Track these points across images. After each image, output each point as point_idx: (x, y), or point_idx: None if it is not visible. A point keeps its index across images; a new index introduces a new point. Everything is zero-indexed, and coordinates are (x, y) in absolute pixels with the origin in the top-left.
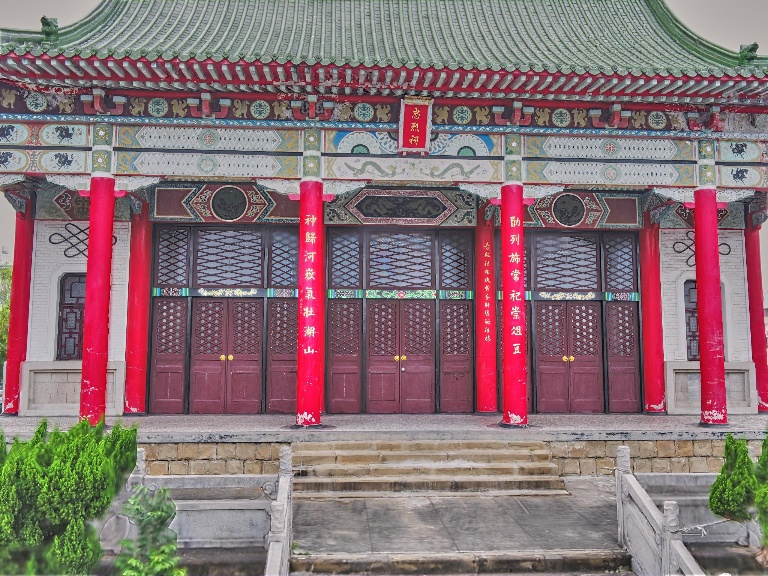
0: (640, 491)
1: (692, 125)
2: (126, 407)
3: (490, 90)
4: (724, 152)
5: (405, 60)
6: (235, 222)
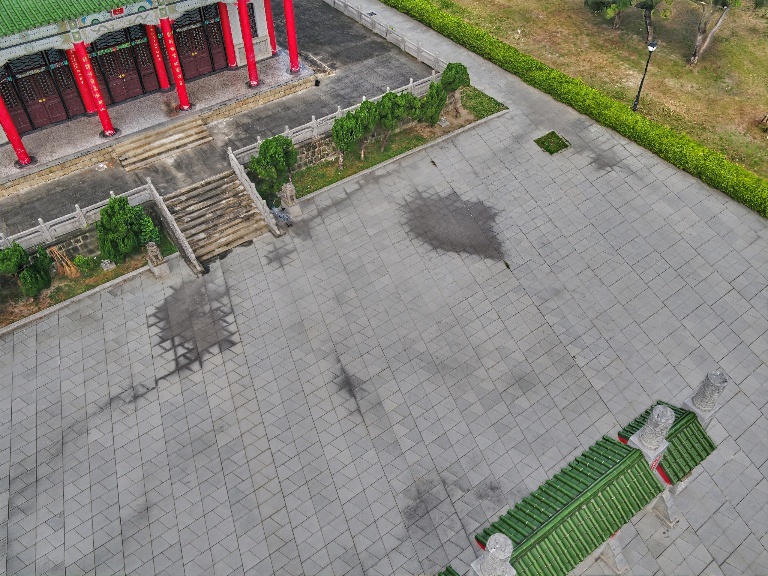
0: (235, 160)
1: None
2: None
3: None
4: None
5: (118, 5)
6: None
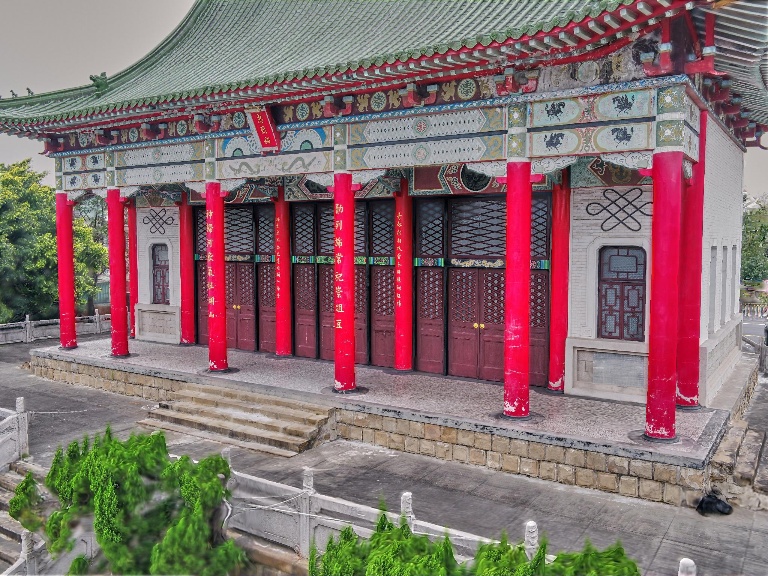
0: None
1: (499, 90)
2: (181, 339)
3: (288, 95)
4: (537, 116)
5: (204, 88)
6: (232, 203)
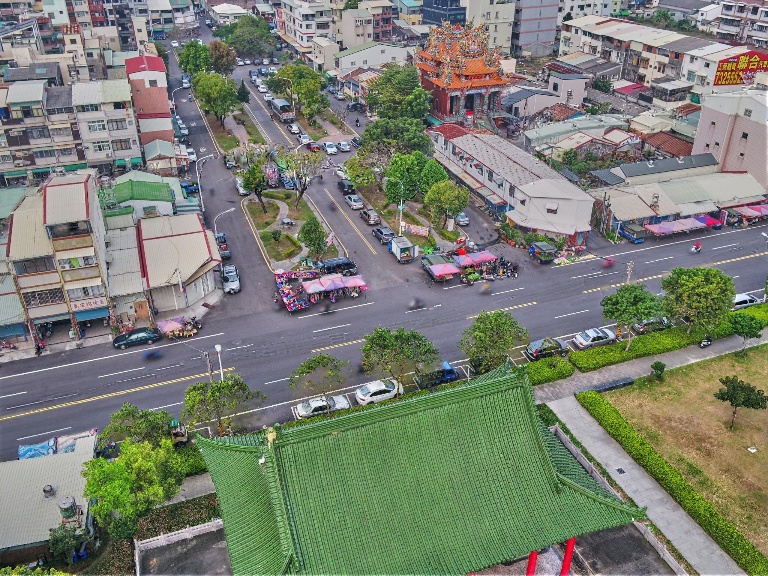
0: None
1: None
2: None
3: None
4: None
5: None
6: None
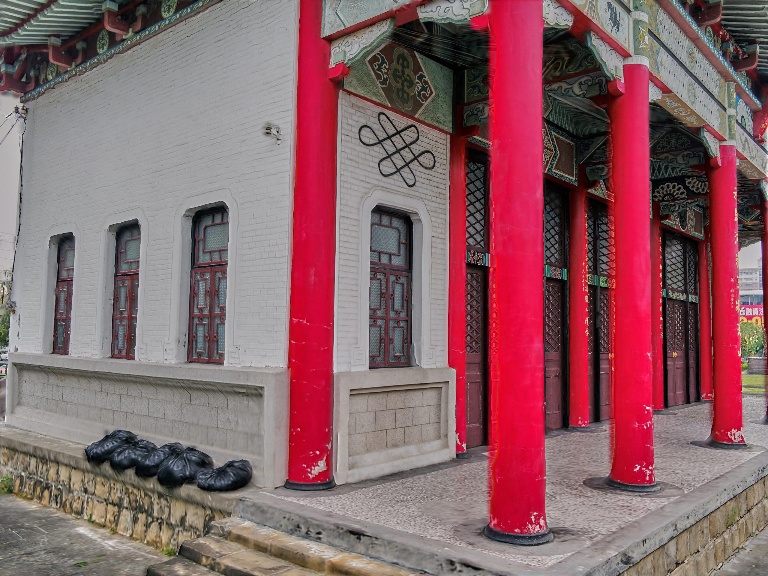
0: None
1: None
2: (457, 444)
3: None
4: None
5: None
6: None
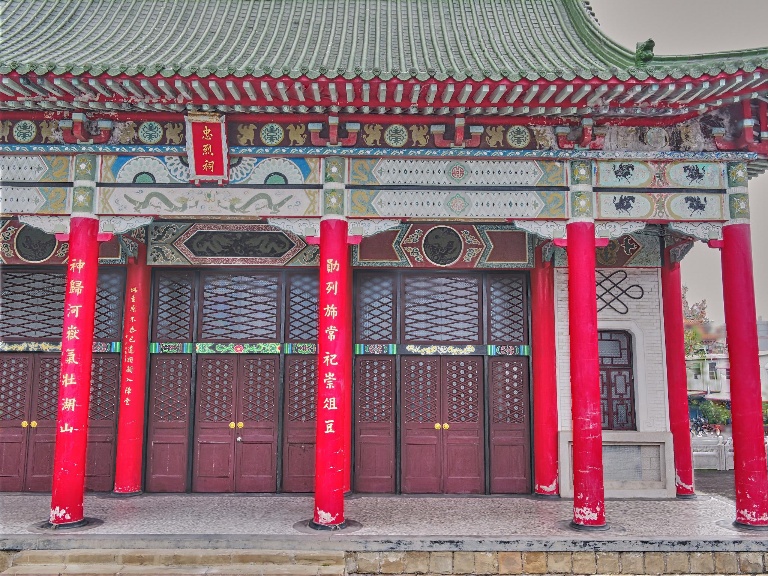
0: None
1: (562, 142)
2: None
3: (287, 103)
4: (604, 175)
5: (160, 66)
6: (42, 263)
